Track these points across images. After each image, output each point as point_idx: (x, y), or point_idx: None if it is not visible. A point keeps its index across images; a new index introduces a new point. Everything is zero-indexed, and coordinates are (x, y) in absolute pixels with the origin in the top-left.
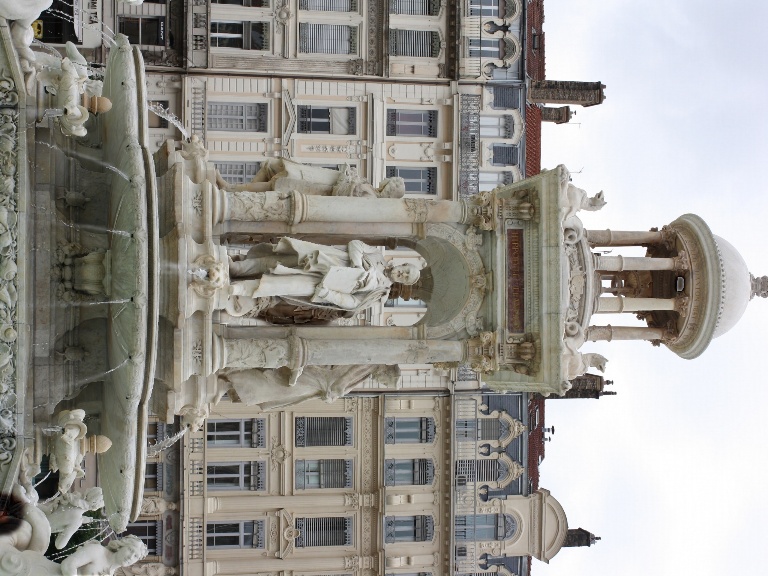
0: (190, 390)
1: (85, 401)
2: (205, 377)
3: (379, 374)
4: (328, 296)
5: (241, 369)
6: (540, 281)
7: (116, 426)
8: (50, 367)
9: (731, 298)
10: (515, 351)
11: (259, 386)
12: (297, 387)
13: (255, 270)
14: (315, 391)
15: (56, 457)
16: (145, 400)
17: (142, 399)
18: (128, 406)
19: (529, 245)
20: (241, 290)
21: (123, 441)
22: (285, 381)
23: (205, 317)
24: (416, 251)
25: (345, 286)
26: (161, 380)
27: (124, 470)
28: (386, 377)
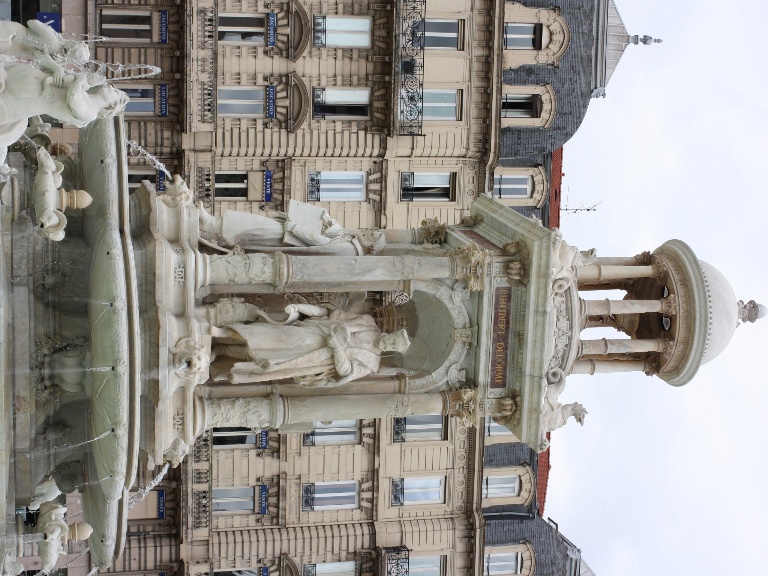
0: (182, 321)
1: (70, 317)
2: (196, 318)
3: (383, 336)
4: (297, 227)
5: (233, 317)
6: (500, 229)
7: (99, 244)
8: (27, 215)
9: (704, 264)
10: (500, 252)
11: (256, 327)
12: (297, 330)
13: (225, 244)
14: (319, 340)
15: (34, 185)
16: (123, 196)
17: (121, 206)
18: (105, 182)
19: (482, 230)
20: (210, 216)
21: (107, 235)
22: (282, 321)
23: (180, 239)
24: (404, 366)
25: (312, 226)
26: (145, 274)
27: (111, 250)
28: (391, 335)
